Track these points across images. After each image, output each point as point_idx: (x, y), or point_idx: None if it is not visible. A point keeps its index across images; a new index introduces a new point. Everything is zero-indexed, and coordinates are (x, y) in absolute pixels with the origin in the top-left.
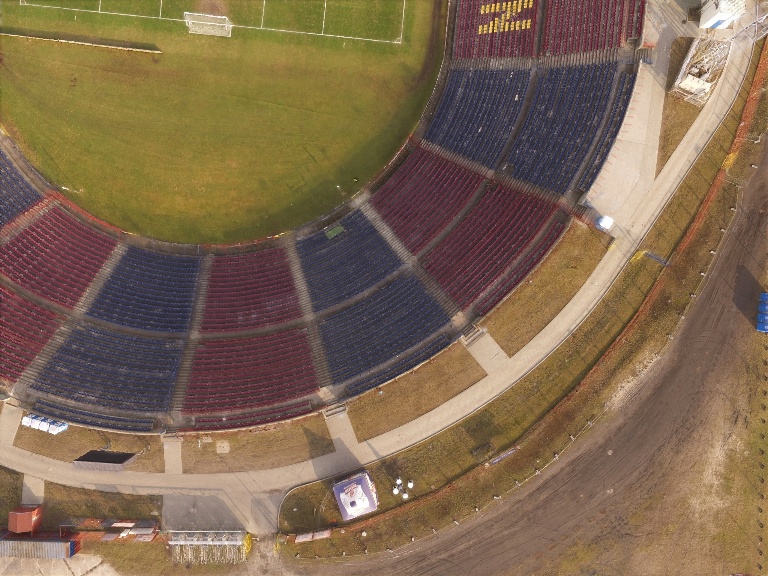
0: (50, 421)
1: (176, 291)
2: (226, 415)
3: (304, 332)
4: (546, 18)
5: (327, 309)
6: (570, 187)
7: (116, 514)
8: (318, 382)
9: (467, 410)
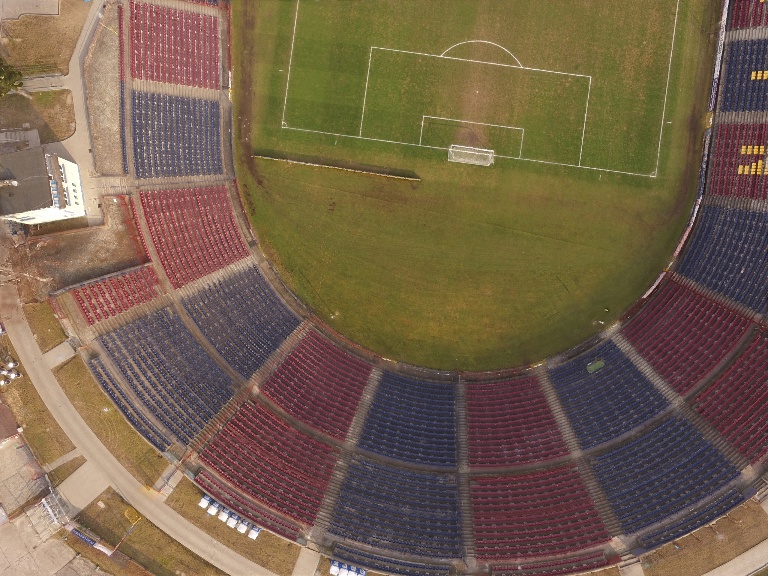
0: (355, 569)
1: (436, 420)
2: (519, 563)
3: (577, 472)
4: None
5: (594, 447)
6: None
7: None
8: (608, 531)
9: (758, 564)
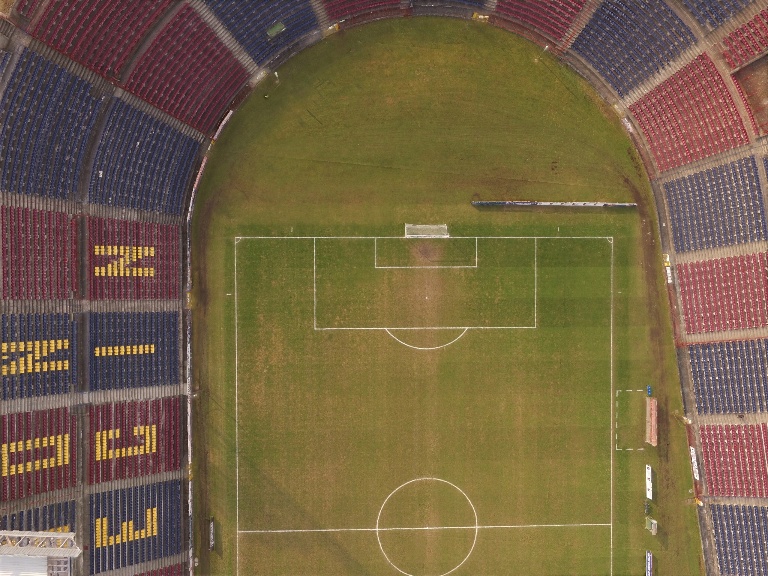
0: None
1: None
2: None
3: None
4: (77, 253)
5: None
6: (18, 54)
7: None
8: None
9: None
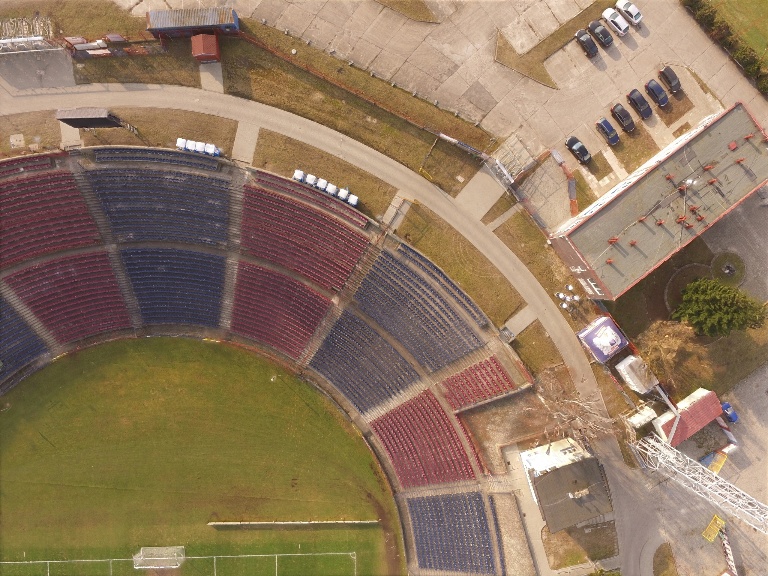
0: None
1: (153, 289)
2: (24, 174)
3: None
4: None
5: None
6: None
7: (120, 61)
8: None
9: None
